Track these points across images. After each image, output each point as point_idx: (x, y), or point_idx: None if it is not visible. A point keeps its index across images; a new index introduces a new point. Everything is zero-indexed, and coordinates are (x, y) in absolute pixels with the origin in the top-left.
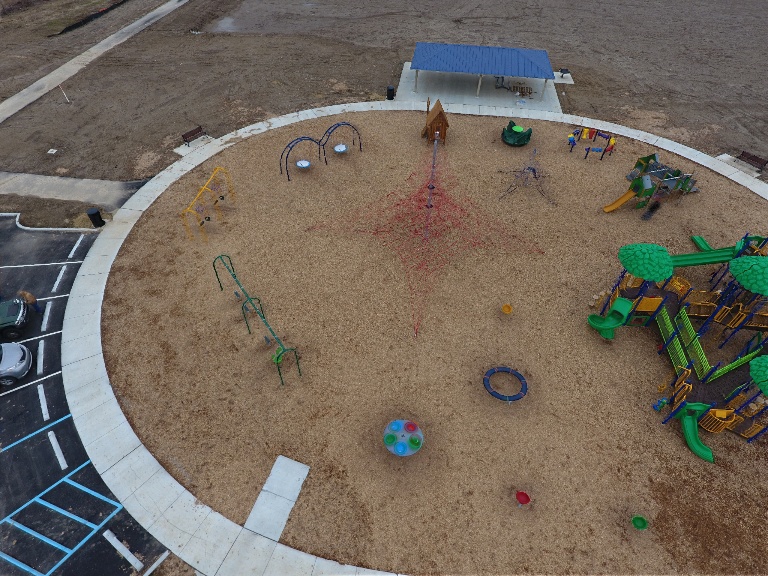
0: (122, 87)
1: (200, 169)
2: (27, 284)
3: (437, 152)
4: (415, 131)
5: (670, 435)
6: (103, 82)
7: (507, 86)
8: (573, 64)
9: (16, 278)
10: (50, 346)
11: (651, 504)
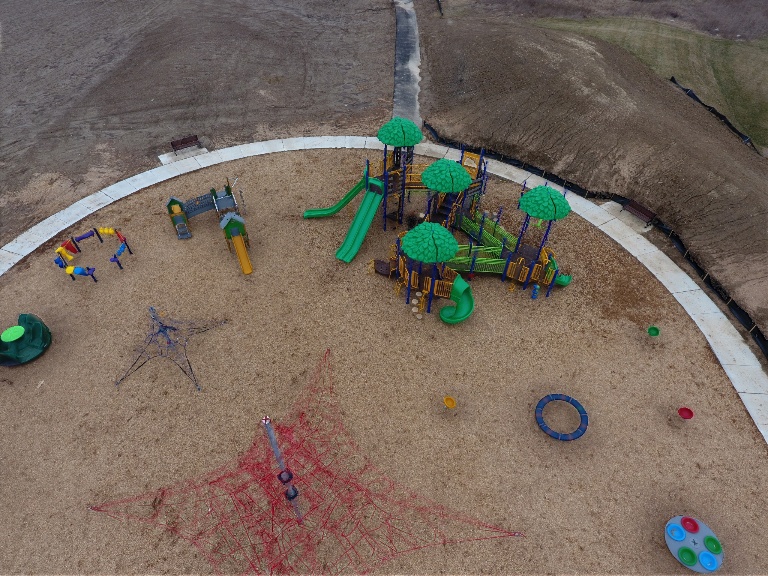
0: None
1: None
2: None
3: None
4: None
5: (556, 295)
6: None
7: None
8: None
9: None
10: None
11: (624, 323)
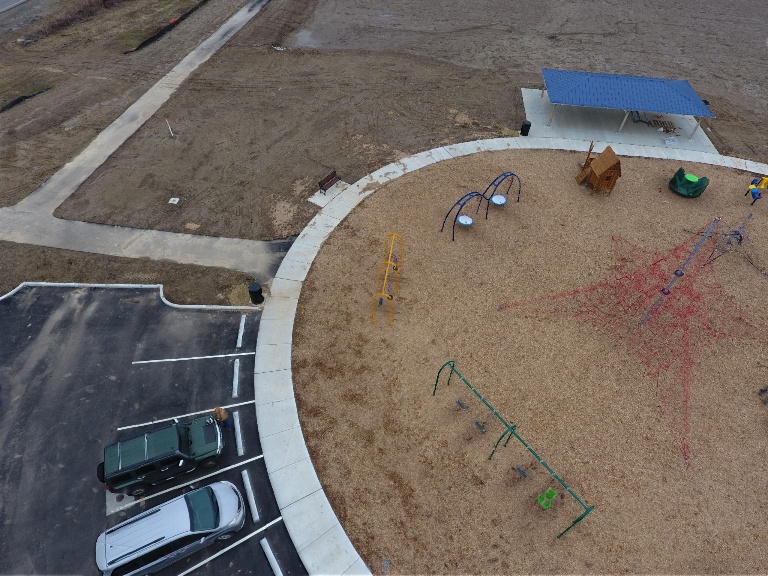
0: (225, 117)
1: (347, 225)
2: (200, 385)
3: (604, 204)
4: (568, 176)
5: None
6: (202, 111)
7: (645, 120)
8: (701, 92)
9: (184, 376)
10: (256, 478)
11: None
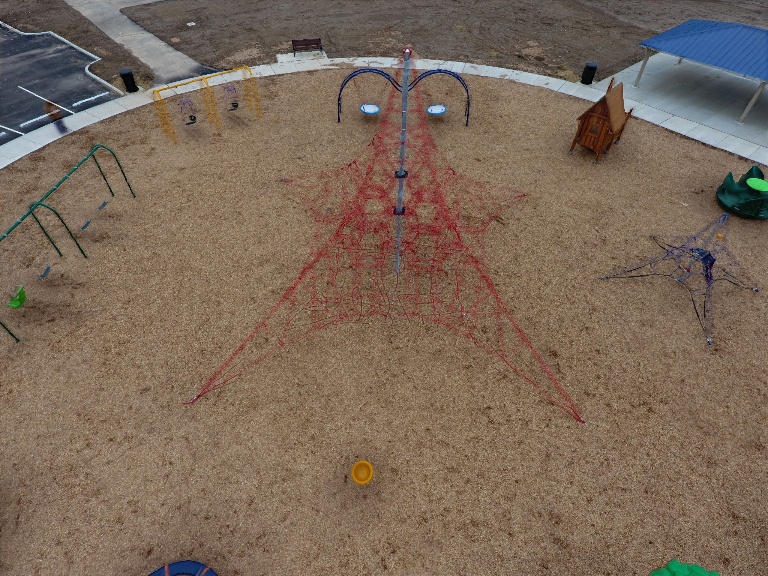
0: None
1: (274, 78)
2: (20, 112)
3: (574, 167)
4: (574, 130)
5: None
6: None
7: None
8: None
9: (23, 104)
10: None
11: None
